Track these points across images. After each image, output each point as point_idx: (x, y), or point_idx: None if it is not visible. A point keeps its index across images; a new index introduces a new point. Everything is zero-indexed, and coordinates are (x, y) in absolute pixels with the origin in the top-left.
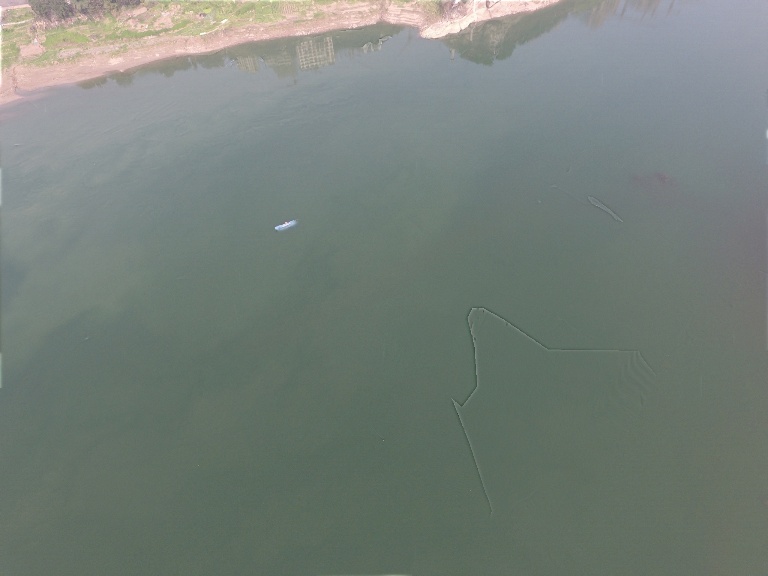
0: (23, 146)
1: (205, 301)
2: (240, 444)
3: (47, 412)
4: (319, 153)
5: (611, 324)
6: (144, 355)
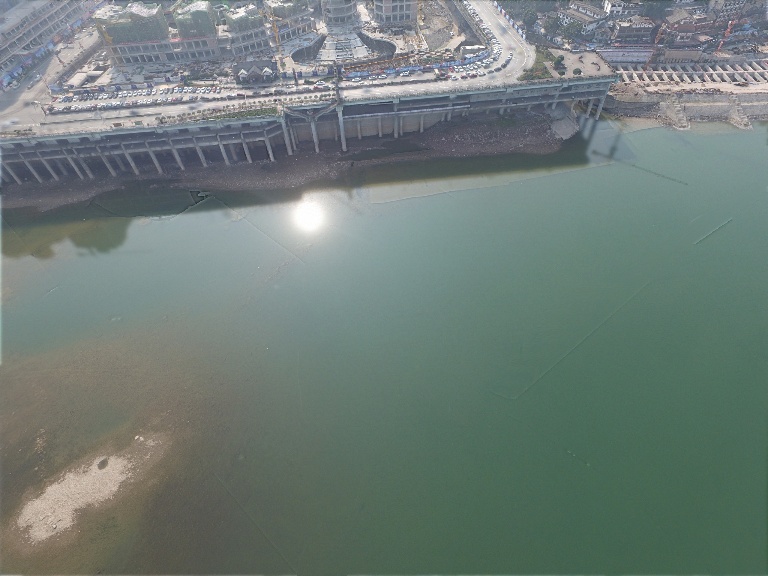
0: None
1: None
2: None
3: None
4: None
5: (518, 476)
6: None
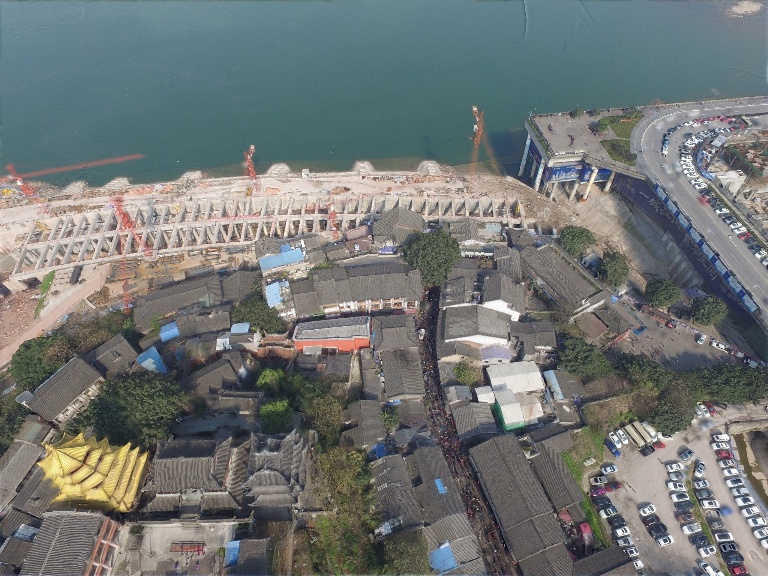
0: None
1: (369, 17)
2: (410, 44)
3: None
4: None
5: None
6: (347, 32)
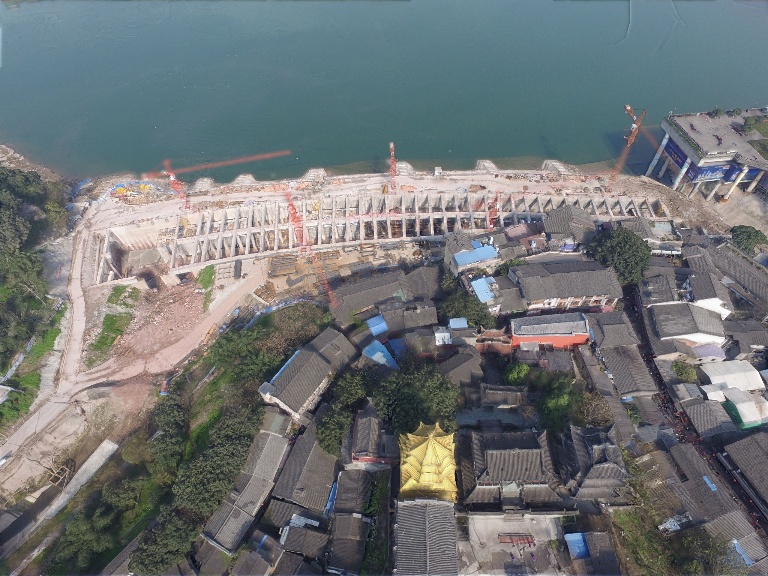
0: None
1: (452, 17)
2: (503, 44)
3: None
4: None
5: None
6: (434, 32)
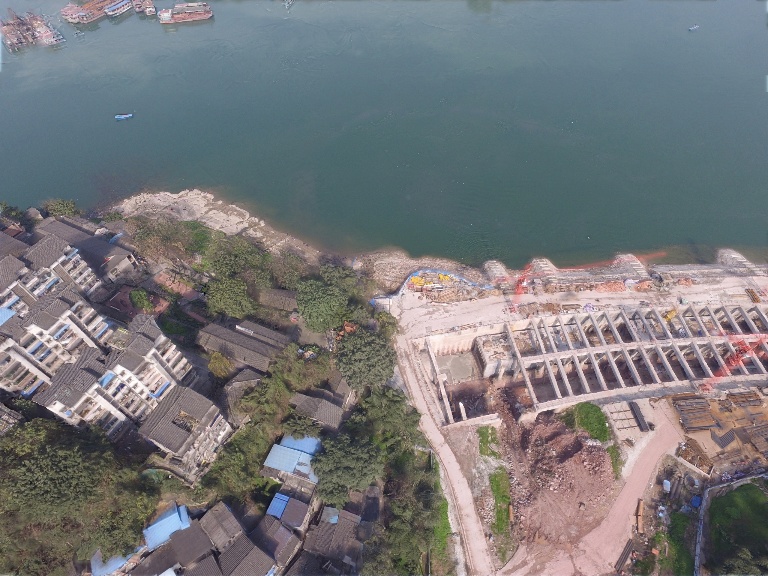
0: (464, 0)
1: (675, 56)
2: None
3: (638, 88)
4: (667, 5)
5: None
6: None
